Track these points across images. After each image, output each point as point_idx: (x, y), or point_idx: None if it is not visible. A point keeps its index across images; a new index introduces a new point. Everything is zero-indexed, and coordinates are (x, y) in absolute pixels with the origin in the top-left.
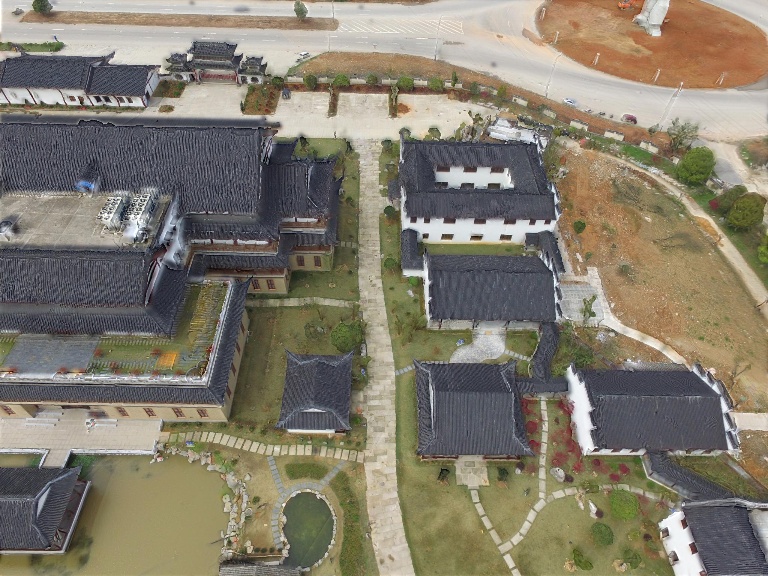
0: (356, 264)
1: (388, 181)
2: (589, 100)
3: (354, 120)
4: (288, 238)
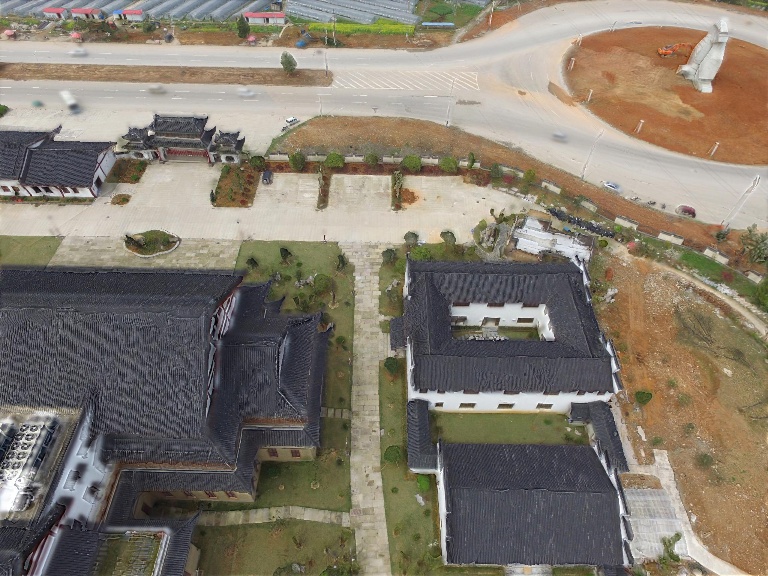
0: (347, 446)
1: (390, 309)
2: (634, 182)
3: (349, 214)
4: (253, 437)
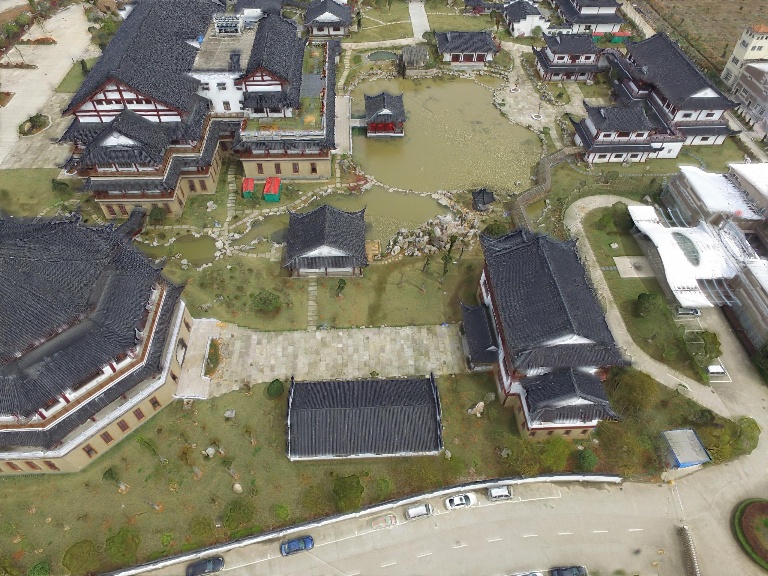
0: None
1: None
2: None
3: (49, 58)
4: None
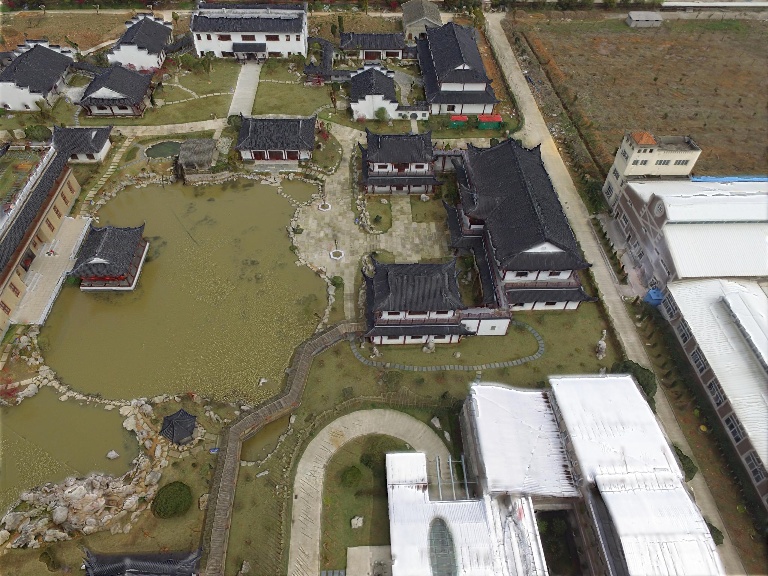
0: None
1: None
2: None
3: None
4: None
